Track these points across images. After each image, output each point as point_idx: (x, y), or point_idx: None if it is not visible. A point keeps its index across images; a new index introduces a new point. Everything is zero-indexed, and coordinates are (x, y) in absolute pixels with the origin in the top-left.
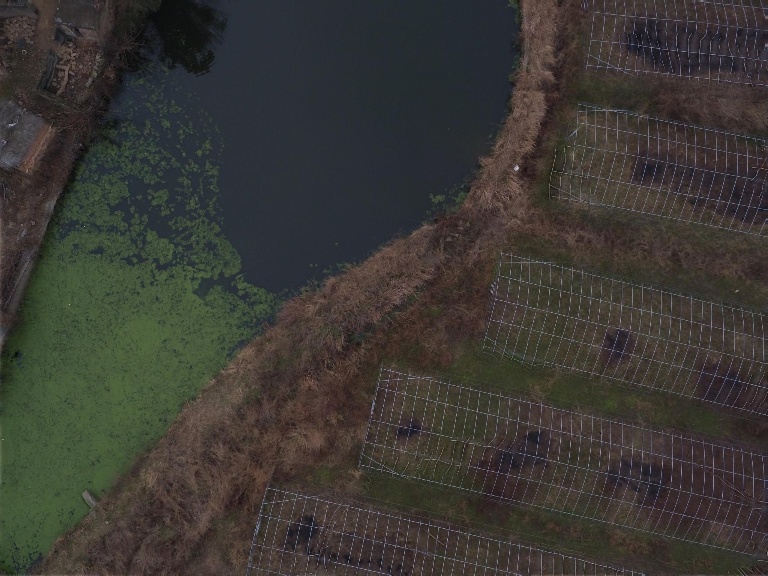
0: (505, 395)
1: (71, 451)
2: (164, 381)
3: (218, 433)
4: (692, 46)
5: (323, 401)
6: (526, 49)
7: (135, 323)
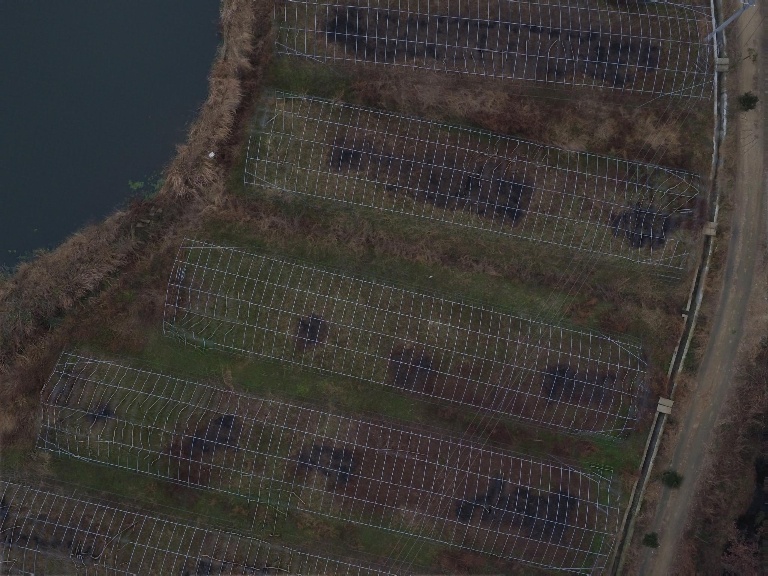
0: (182, 378)
1: None
2: None
3: None
4: (390, 33)
5: (14, 385)
6: (225, 36)
7: None
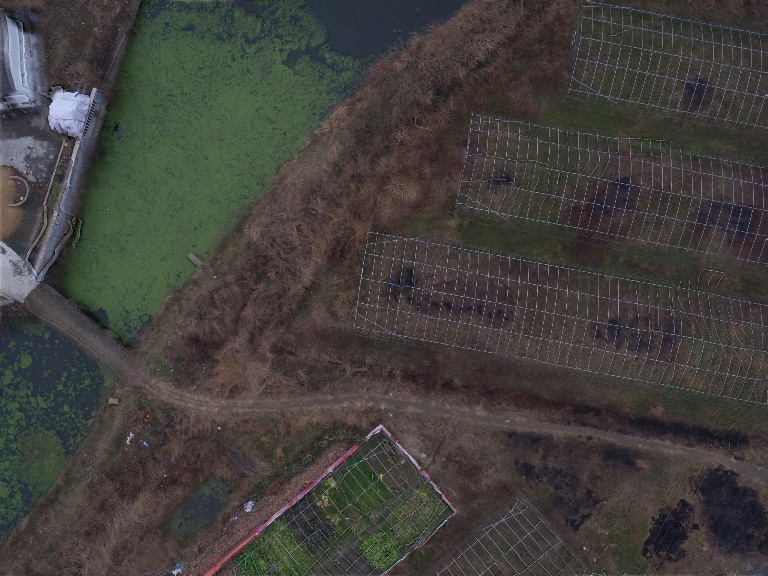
0: (593, 133)
1: (174, 218)
2: (259, 147)
3: (316, 190)
4: None
5: (415, 155)
6: None
7: (228, 94)
